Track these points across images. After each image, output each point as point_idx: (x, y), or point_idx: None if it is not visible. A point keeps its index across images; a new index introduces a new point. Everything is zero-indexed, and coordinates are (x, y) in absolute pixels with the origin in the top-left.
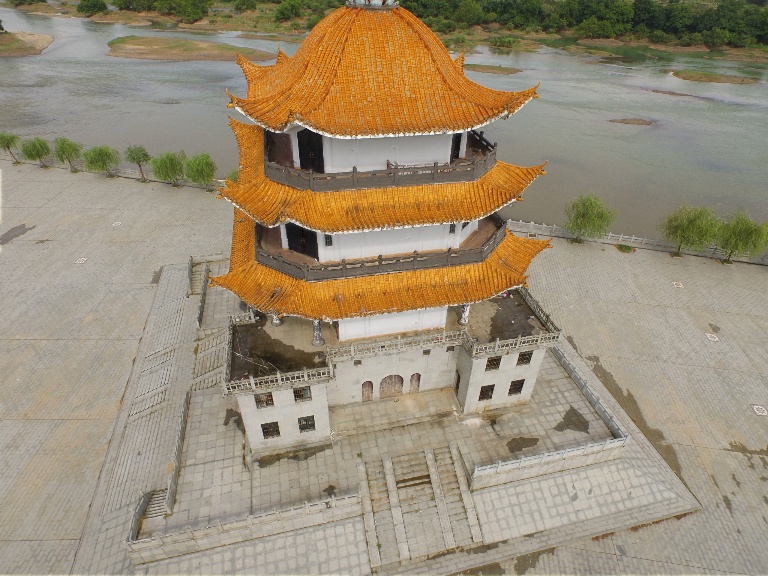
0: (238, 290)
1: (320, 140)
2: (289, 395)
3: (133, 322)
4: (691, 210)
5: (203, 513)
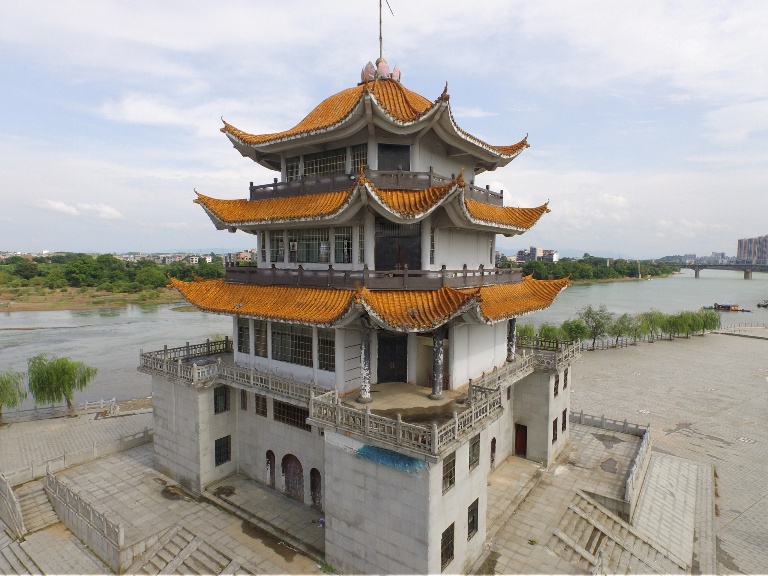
0: None
1: (406, 158)
2: (466, 457)
3: None
4: None
5: None
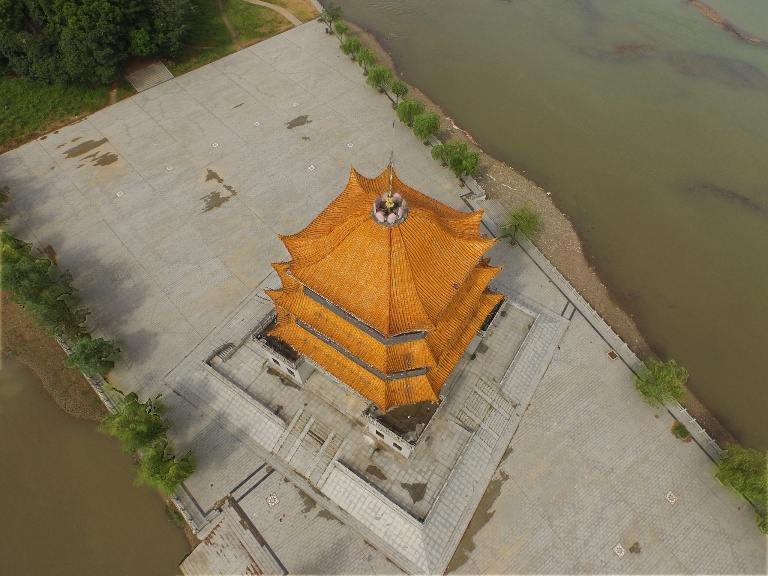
0: None
1: None
2: None
3: None
4: (753, 461)
5: (234, 372)
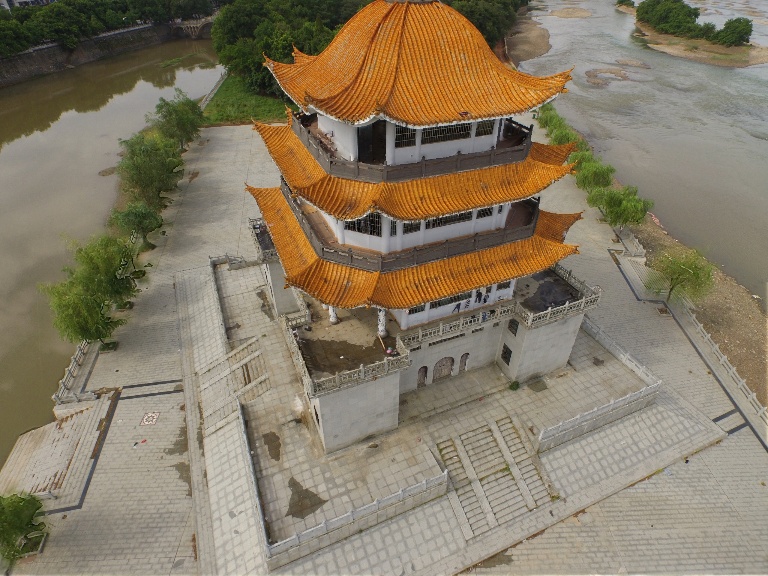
0: None
1: None
2: None
3: None
4: None
5: (228, 280)
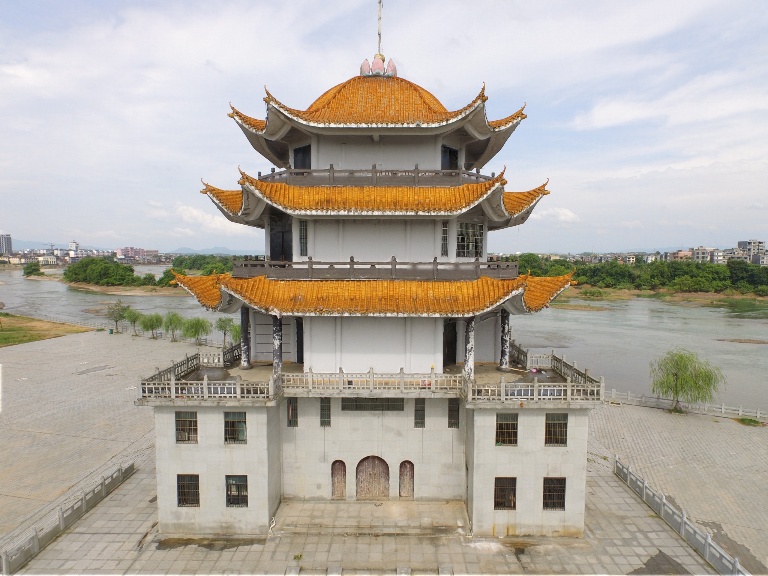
0: (199, 292)
1: (310, 157)
2: (218, 427)
3: (138, 429)
4: None
5: None
